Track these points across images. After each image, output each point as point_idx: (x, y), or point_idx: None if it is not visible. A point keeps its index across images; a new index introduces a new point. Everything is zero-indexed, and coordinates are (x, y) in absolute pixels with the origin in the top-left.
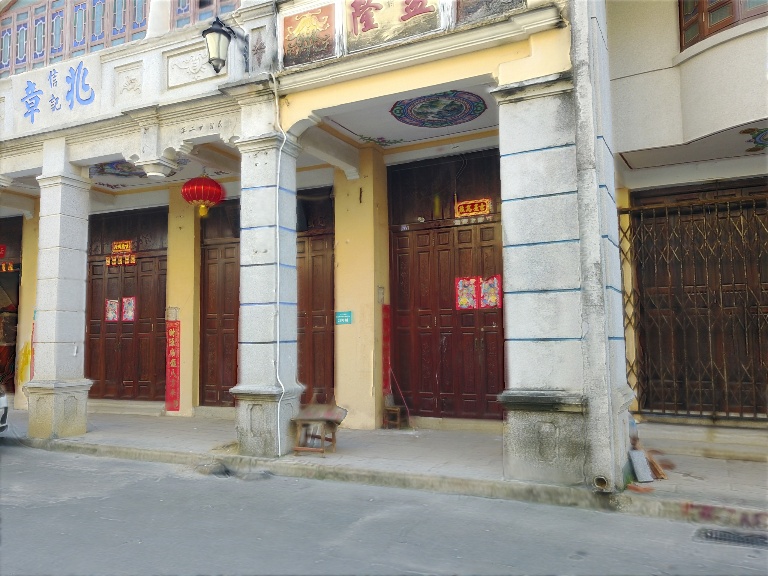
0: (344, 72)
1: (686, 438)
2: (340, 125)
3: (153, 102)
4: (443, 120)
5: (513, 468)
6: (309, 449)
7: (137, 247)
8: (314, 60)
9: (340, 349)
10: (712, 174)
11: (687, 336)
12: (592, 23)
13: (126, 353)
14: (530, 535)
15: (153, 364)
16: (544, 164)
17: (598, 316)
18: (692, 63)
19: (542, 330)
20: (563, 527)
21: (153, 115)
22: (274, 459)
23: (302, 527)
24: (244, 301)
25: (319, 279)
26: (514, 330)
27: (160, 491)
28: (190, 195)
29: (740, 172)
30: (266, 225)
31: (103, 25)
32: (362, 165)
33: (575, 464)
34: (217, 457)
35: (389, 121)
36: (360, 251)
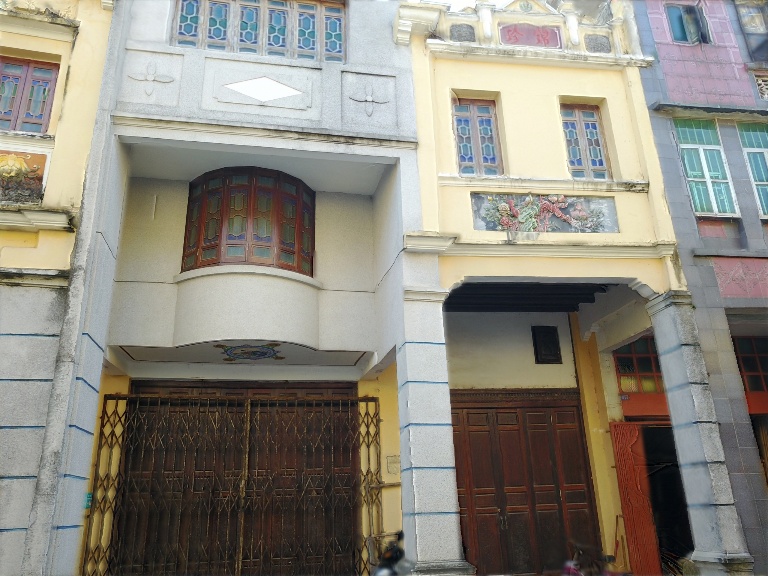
0: None
1: None
2: None
3: None
4: None
5: None
6: None
7: None
8: None
9: None
10: (199, 374)
11: (160, 519)
12: (96, 236)
13: None
14: None
15: None
16: (28, 349)
17: (48, 505)
18: (186, 284)
19: None
20: None
21: None
22: None
23: None
24: None
25: None
26: None
27: None
28: None
29: (220, 375)
30: None
31: None
32: None
33: None
34: None
35: None
36: None
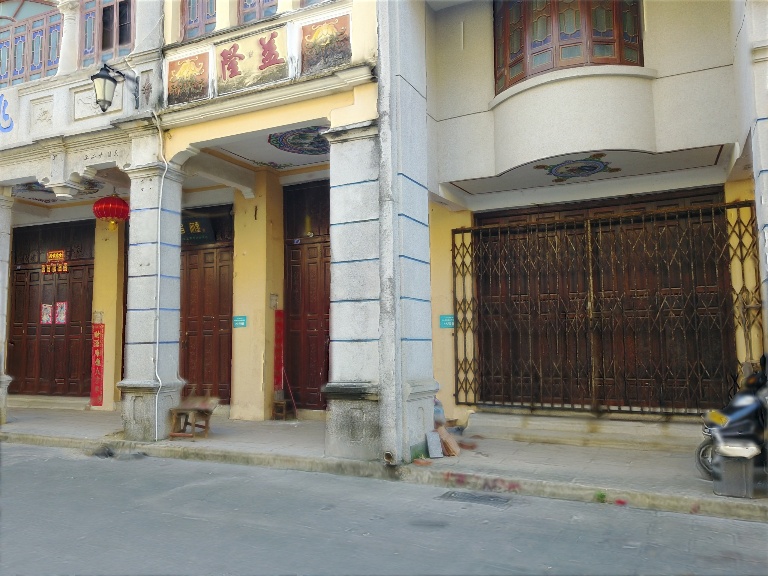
0: (212, 112)
1: (506, 425)
2: (230, 152)
3: (59, 133)
4: (319, 149)
5: (332, 447)
6: (182, 434)
7: (69, 256)
8: (192, 100)
9: (237, 349)
10: (534, 200)
11: (512, 338)
12: (396, 80)
13: (58, 353)
14: (310, 495)
15: (82, 363)
16: (361, 195)
17: (390, 321)
18: (500, 109)
19: (356, 333)
20: (344, 491)
21: (60, 144)
22: (150, 443)
23: (134, 491)
24: (130, 307)
25: (225, 287)
26: (336, 333)
27: (39, 467)
28: (99, 213)
29: (555, 198)
30: (149, 242)
31: (23, 61)
32: (257, 186)
33: (376, 443)
34: (105, 442)
35: (271, 149)
36: (254, 262)
